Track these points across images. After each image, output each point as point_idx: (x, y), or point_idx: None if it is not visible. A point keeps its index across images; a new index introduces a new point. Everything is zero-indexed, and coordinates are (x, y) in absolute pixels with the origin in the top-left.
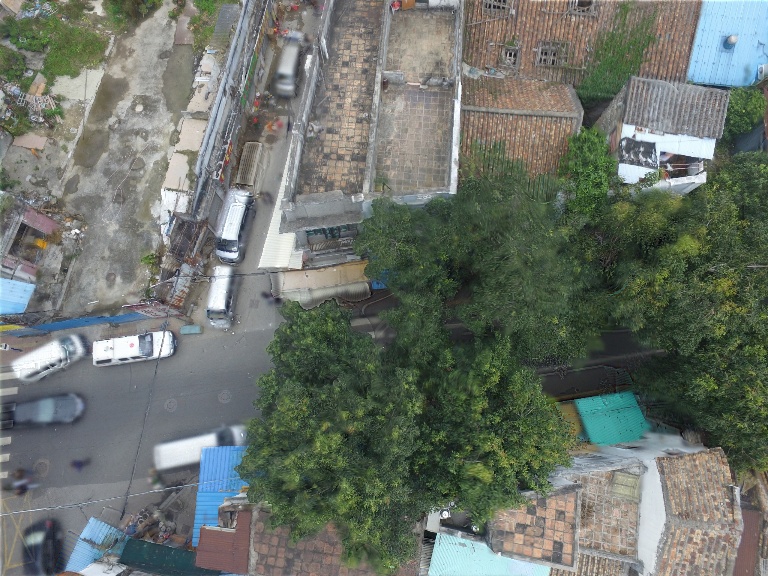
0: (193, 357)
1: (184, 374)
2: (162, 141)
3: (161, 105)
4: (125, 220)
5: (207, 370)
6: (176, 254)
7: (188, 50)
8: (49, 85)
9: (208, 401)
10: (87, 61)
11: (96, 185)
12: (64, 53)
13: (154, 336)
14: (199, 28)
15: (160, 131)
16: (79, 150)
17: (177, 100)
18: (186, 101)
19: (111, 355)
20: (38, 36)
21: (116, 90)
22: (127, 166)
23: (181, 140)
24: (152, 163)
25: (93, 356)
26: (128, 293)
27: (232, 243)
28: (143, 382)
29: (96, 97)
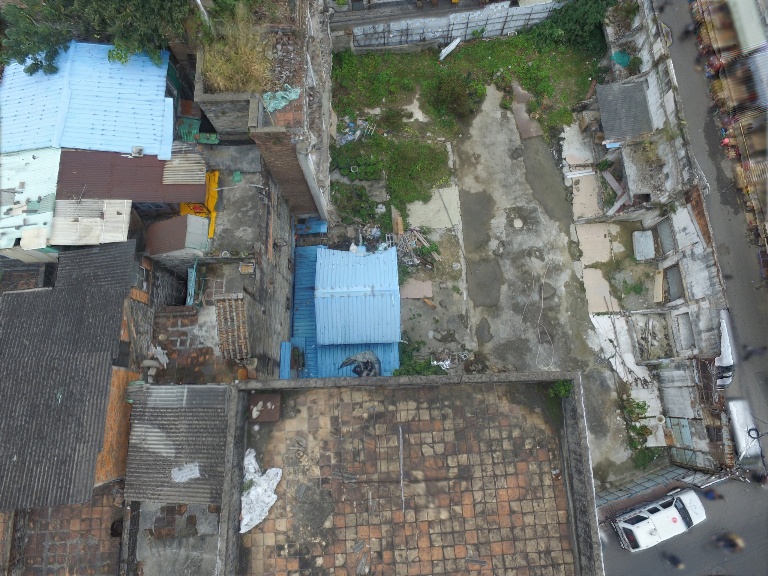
0: (716, 510)
1: (717, 533)
2: (562, 257)
3: (540, 214)
4: (564, 361)
5: (740, 523)
6: (707, 403)
7: (540, 143)
8: (405, 217)
9: (758, 560)
10: (435, 179)
11: (511, 326)
12: (405, 175)
13: (683, 500)
14: (542, 114)
15: (554, 246)
16: (472, 288)
17: (556, 205)
18: (566, 204)
19: (658, 538)
20: (370, 161)
21: (481, 207)
22: (536, 296)
23: (584, 252)
24: (562, 286)
25: (642, 545)
26: (608, 449)
27: (728, 369)
28: (674, 554)
29: (462, 220)
